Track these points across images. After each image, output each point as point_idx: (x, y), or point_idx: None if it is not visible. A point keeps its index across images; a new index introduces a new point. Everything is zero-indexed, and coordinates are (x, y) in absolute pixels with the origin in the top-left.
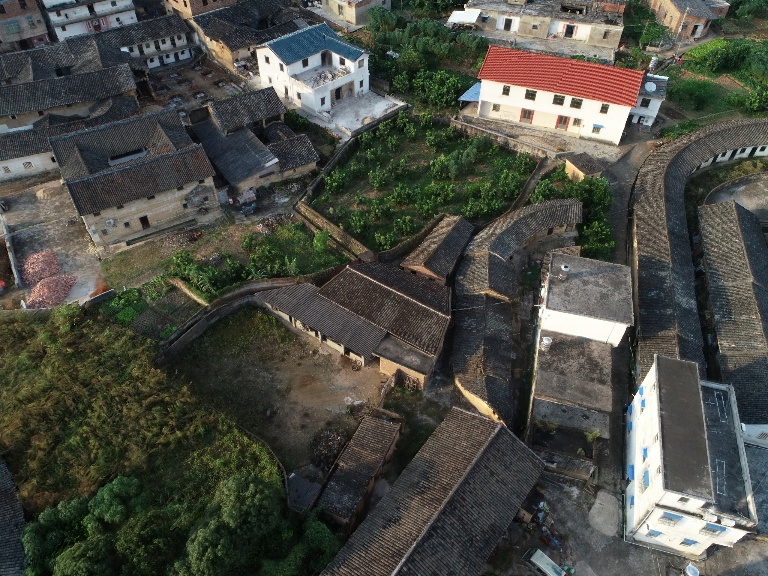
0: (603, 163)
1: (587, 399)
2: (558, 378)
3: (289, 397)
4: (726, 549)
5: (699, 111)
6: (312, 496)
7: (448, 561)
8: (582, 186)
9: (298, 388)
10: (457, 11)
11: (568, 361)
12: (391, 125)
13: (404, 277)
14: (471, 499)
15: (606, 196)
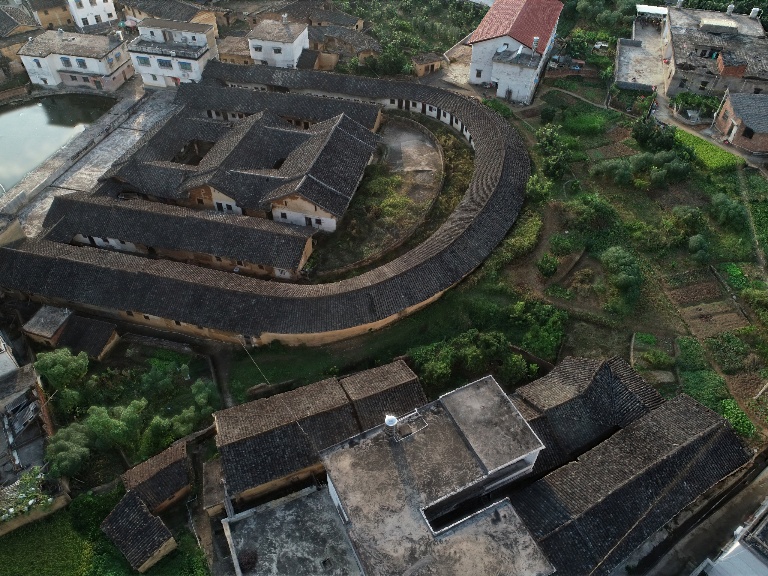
0: (442, 76)
1: (220, 46)
2: (235, 41)
3: (254, 5)
4: (144, 93)
5: (541, 124)
6: (199, 1)
7: (152, 4)
8: (391, 50)
9: (259, 6)
10: (665, 8)
11: (245, 44)
12: (471, 7)
13: (310, 7)
14: (172, 6)
15: (382, 60)
